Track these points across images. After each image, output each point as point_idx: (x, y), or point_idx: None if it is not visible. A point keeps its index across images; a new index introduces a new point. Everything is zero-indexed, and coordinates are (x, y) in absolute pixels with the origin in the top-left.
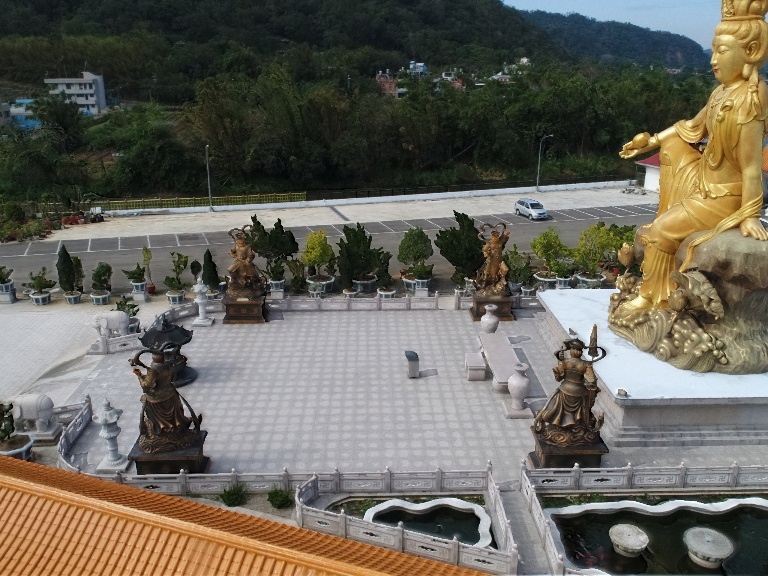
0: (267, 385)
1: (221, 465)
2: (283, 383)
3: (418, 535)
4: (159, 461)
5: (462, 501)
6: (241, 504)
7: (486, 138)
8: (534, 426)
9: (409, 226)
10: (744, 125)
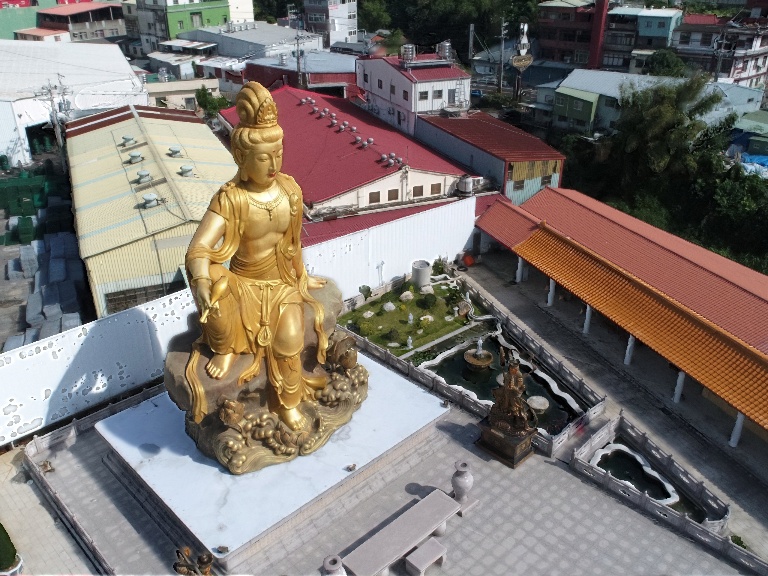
0: None
1: None
2: None
3: None
4: None
5: None
6: None
7: None
8: None
9: None
10: None
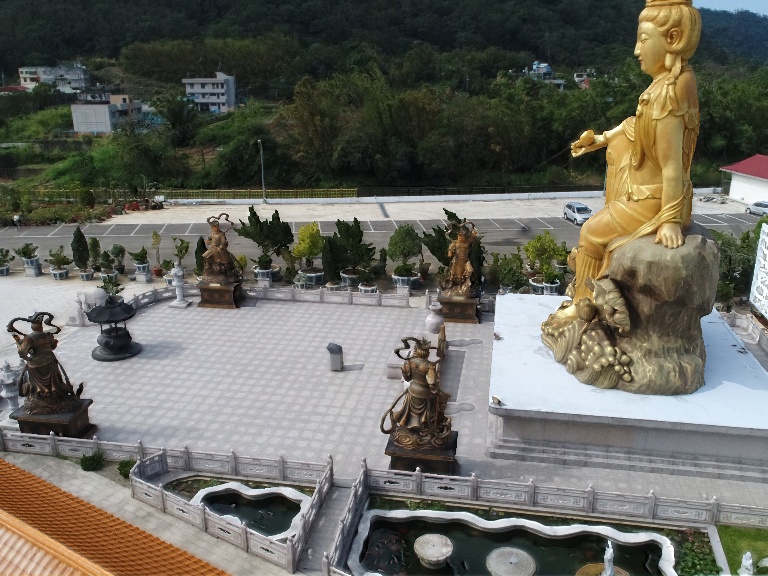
0: (195, 365)
1: (104, 433)
2: (211, 365)
3: (216, 516)
4: (36, 422)
5: (296, 492)
6: (96, 470)
7: None
8: (380, 425)
9: (444, 225)
10: (659, 121)
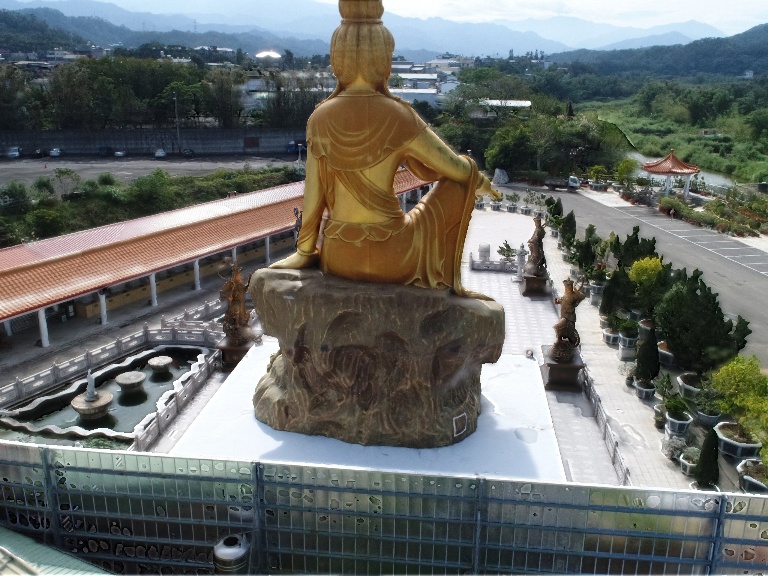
0: None
1: None
2: None
3: (200, 308)
4: None
5: None
6: None
7: None
8: None
9: None
10: None
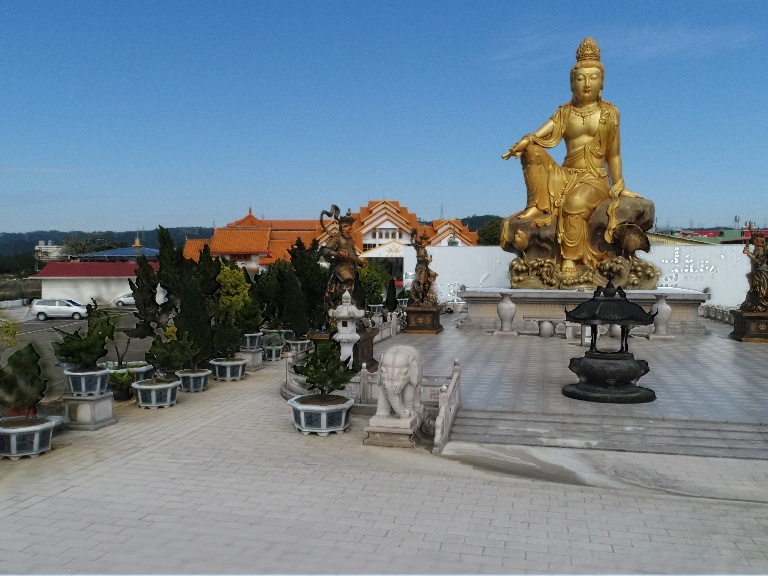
0: None
1: None
2: None
3: None
4: None
5: None
6: None
7: None
8: None
9: None
10: None
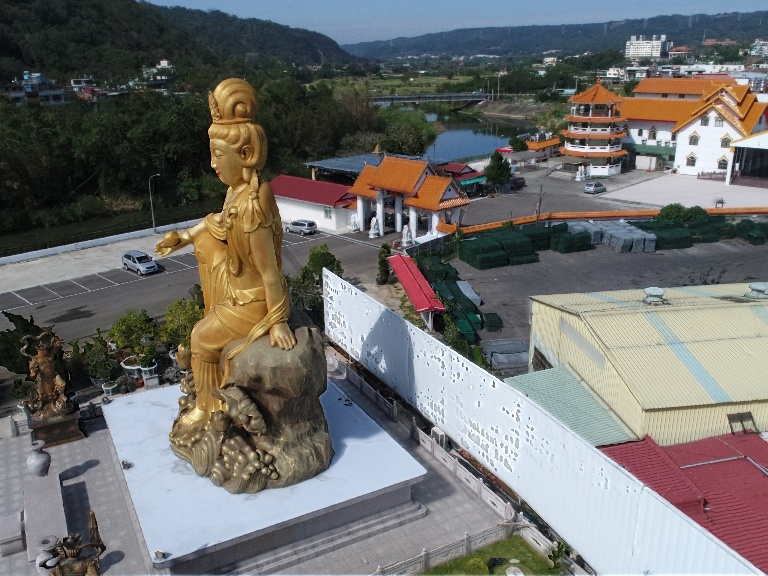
0: None
1: None
2: None
3: None
4: None
5: None
6: None
7: (109, 165)
8: None
9: None
10: (251, 233)
